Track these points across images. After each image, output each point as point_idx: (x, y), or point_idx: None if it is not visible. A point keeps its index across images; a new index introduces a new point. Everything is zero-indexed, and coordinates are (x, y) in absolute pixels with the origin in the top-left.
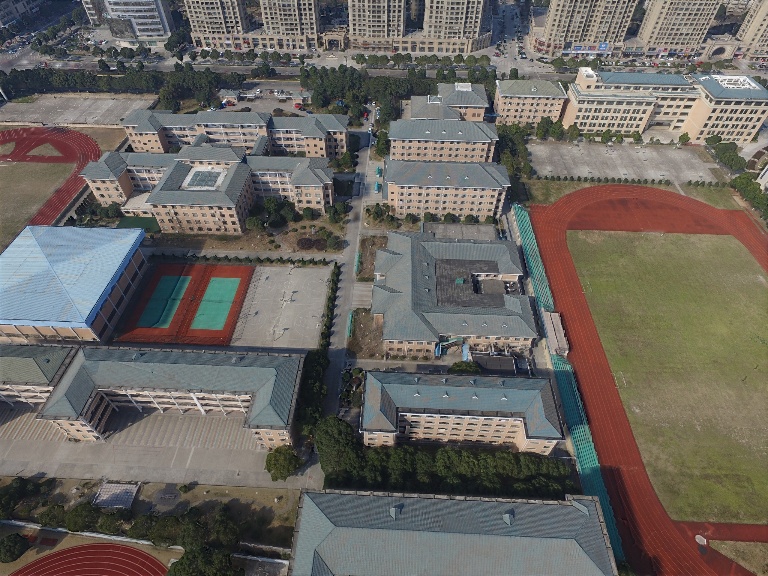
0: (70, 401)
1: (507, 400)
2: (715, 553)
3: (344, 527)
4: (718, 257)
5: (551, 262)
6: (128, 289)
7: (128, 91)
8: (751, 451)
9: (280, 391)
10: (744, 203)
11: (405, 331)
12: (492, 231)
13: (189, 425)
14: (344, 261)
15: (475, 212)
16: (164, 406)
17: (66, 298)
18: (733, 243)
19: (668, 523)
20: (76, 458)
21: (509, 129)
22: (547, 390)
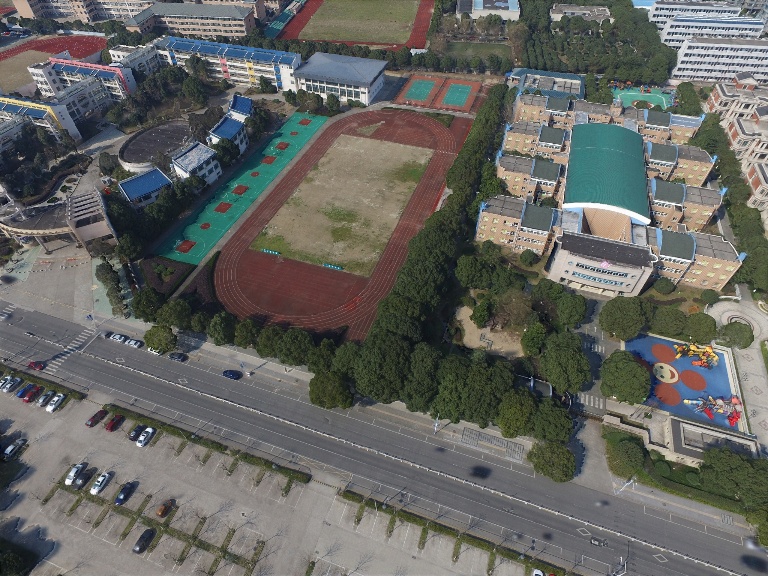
0: None
1: None
2: None
3: (160, 2)
4: None
5: None
6: None
7: None
8: (348, 30)
9: None
10: None
11: None
12: None
13: None
14: None
15: None
16: (116, 13)
17: None
18: None
19: None
20: None
21: None
22: None
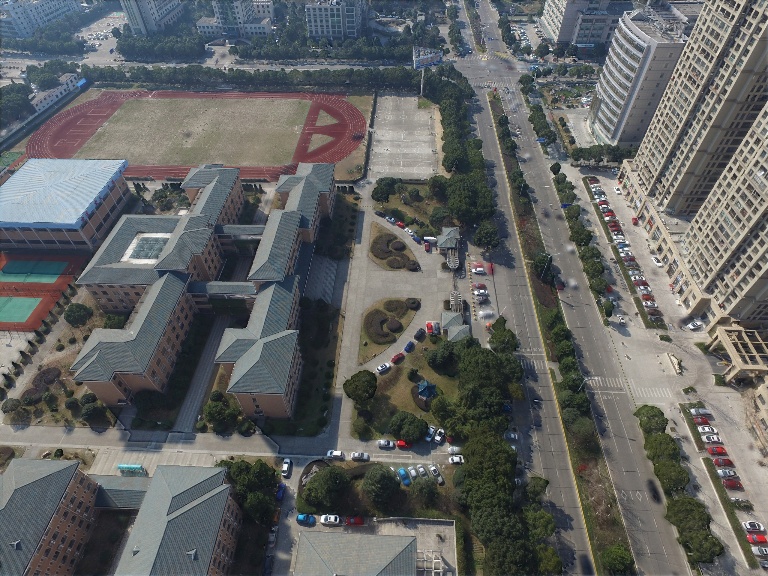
0: None
1: None
2: None
3: None
4: None
5: None
6: (53, 243)
7: None
8: None
9: None
10: None
11: None
12: None
13: None
14: None
15: None
16: None
17: (2, 204)
18: None
19: None
20: None
21: None
22: None
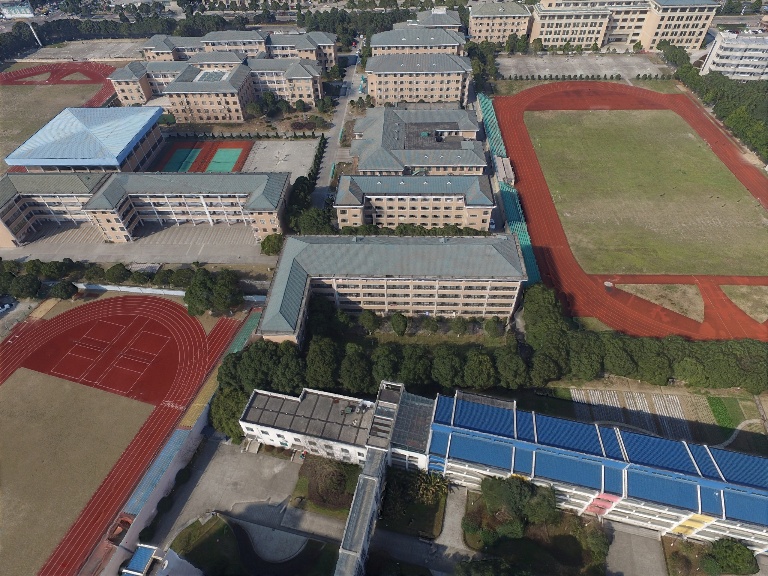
0: (107, 198)
1: (451, 184)
2: (619, 291)
3: (316, 244)
4: (655, 123)
5: (508, 131)
6: (149, 155)
7: (146, 36)
8: (660, 235)
9: (271, 188)
10: (685, 89)
11: (376, 162)
12: (456, 106)
13: (200, 232)
14: (330, 136)
15: (444, 99)
16: (180, 217)
17: (100, 145)
18: (670, 114)
19: (583, 276)
20: (111, 252)
21: (480, 46)
22: (485, 179)
